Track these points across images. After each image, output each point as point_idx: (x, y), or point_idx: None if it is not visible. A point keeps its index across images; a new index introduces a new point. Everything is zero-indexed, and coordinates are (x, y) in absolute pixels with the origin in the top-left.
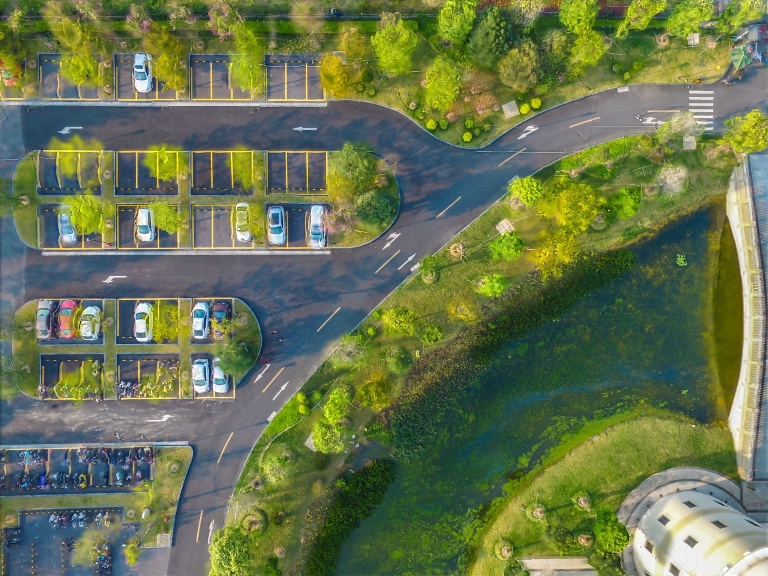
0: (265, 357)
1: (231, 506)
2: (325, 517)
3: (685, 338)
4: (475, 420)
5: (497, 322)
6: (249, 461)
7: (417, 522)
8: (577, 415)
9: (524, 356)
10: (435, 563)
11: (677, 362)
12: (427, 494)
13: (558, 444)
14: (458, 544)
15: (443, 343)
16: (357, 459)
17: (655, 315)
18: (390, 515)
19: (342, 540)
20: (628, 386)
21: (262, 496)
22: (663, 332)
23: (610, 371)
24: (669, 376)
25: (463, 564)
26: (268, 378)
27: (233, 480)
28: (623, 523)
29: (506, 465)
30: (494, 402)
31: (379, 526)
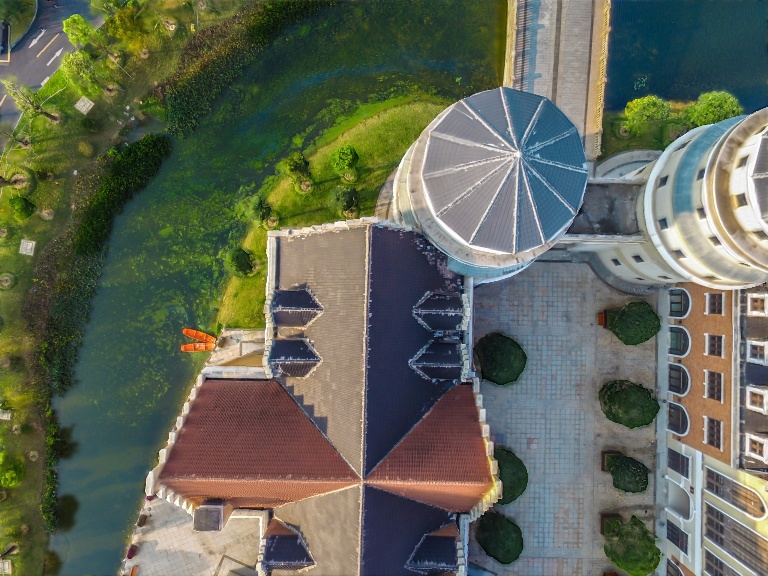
0: (40, 23)
1: (1, 165)
2: (98, 186)
3: (463, 32)
4: (250, 99)
5: (275, 4)
6: (20, 122)
7: (190, 197)
8: (352, 99)
9: (301, 39)
10: (206, 237)
11: (454, 54)
12: (201, 170)
13: (332, 126)
14: (229, 220)
15: (219, 20)
16: (133, 133)
17: (432, 5)
18: (163, 189)
19: (113, 208)
20: (403, 72)
21: (31, 156)
22: (441, 25)
23: (385, 57)
24: (443, 64)
25: (234, 239)
26: (43, 43)
27: (4, 141)
28: (388, 197)
29: (280, 144)
30: (270, 83)
31: (152, 199)
